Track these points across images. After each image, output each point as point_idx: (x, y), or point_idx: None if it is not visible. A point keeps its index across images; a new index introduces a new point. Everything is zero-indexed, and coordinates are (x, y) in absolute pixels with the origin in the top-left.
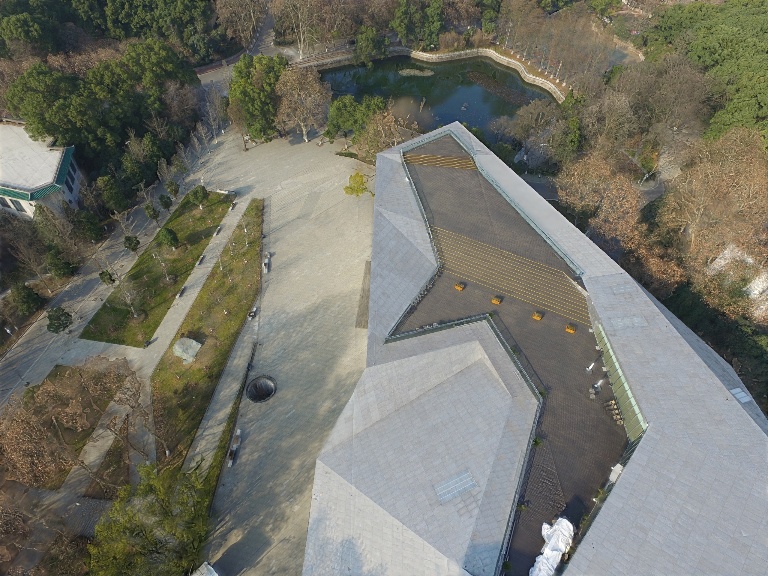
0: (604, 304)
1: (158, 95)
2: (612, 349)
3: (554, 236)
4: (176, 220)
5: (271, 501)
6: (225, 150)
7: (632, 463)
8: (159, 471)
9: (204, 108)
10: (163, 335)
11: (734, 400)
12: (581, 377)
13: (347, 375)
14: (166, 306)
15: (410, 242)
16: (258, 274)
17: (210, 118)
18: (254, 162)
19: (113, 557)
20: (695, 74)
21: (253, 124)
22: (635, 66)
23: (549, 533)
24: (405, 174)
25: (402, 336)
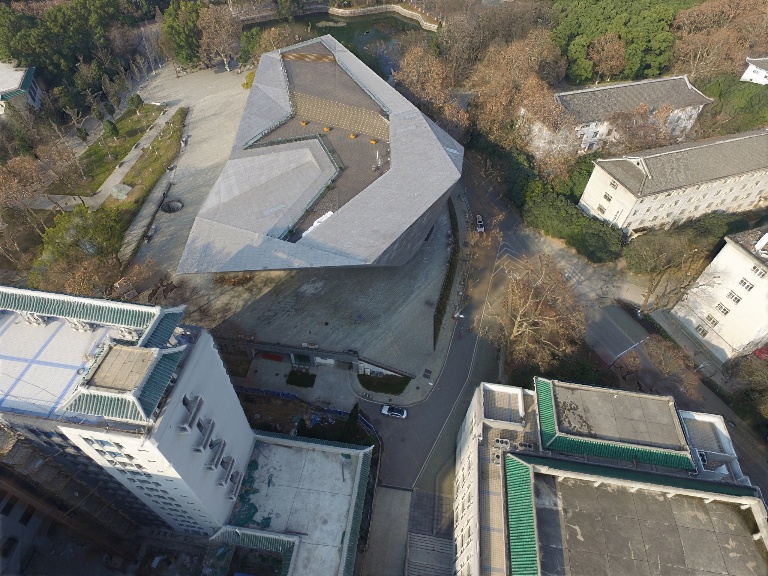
0: (396, 124)
1: (103, 33)
2: None
3: (378, 95)
4: (119, 123)
5: (172, 258)
6: (161, 78)
7: (374, 182)
8: None
9: (141, 43)
10: (105, 189)
11: (443, 149)
12: (371, 162)
13: None
14: (108, 173)
15: (275, 101)
16: (177, 148)
17: (147, 52)
18: (184, 85)
19: (57, 244)
20: (527, 1)
21: (180, 53)
22: (500, 6)
23: None
24: (281, 65)
25: (257, 146)
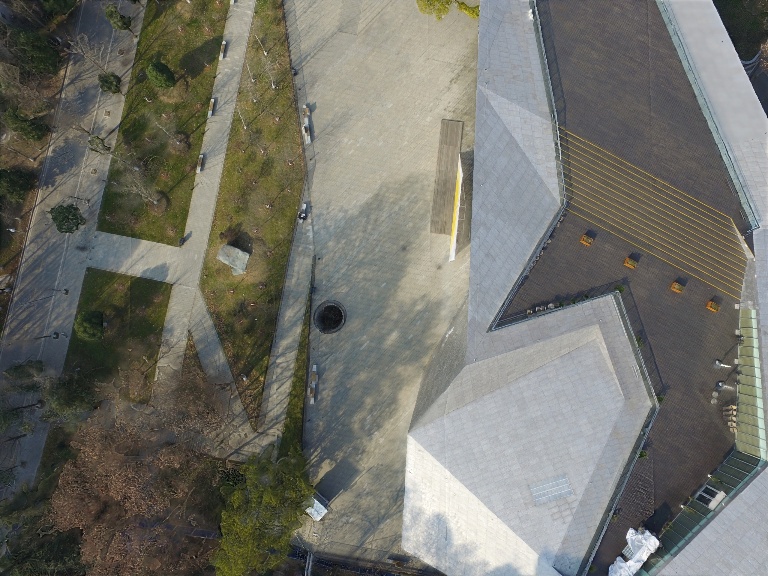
0: None
1: None
2: (760, 353)
3: (737, 150)
4: (156, 23)
5: (357, 434)
6: None
7: (739, 500)
8: (241, 394)
9: None
10: (197, 229)
11: None
12: (707, 373)
13: (423, 298)
14: (188, 185)
15: (527, 158)
16: (298, 144)
17: None
18: None
19: None
20: None
21: None
22: None
23: (634, 539)
24: (528, 0)
25: (508, 320)
